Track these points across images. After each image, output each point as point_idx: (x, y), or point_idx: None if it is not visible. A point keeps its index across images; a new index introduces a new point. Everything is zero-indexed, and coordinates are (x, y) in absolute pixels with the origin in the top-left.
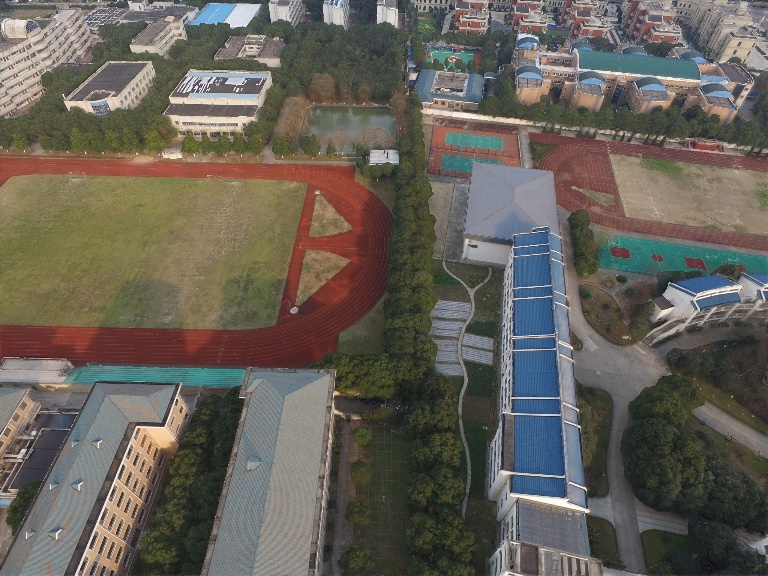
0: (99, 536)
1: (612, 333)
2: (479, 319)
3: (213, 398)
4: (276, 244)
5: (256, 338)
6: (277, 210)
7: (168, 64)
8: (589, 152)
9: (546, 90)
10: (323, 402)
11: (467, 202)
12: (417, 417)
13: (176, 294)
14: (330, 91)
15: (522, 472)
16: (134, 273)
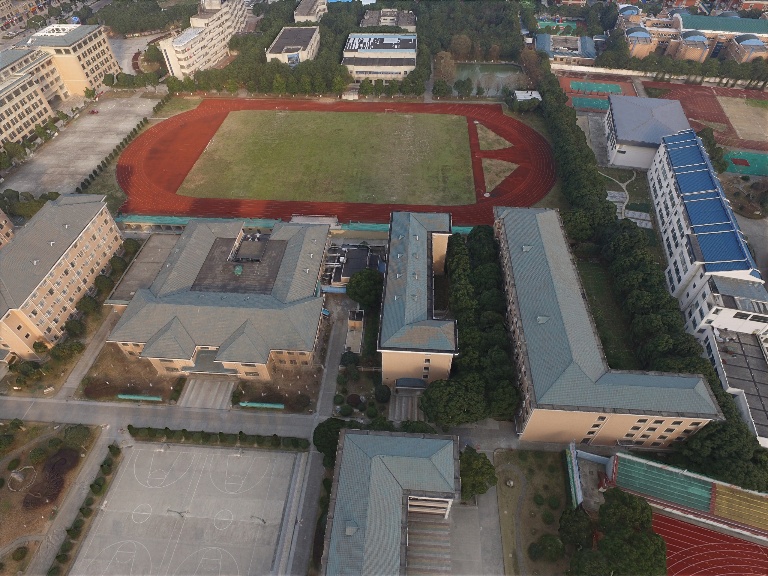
0: None
1: (745, 211)
2: (634, 202)
3: None
4: (457, 154)
5: (465, 210)
6: (448, 133)
7: None
8: (698, 95)
9: (653, 47)
10: (557, 223)
11: (614, 120)
12: (619, 241)
13: (393, 184)
14: (467, 49)
15: (712, 261)
16: (355, 171)
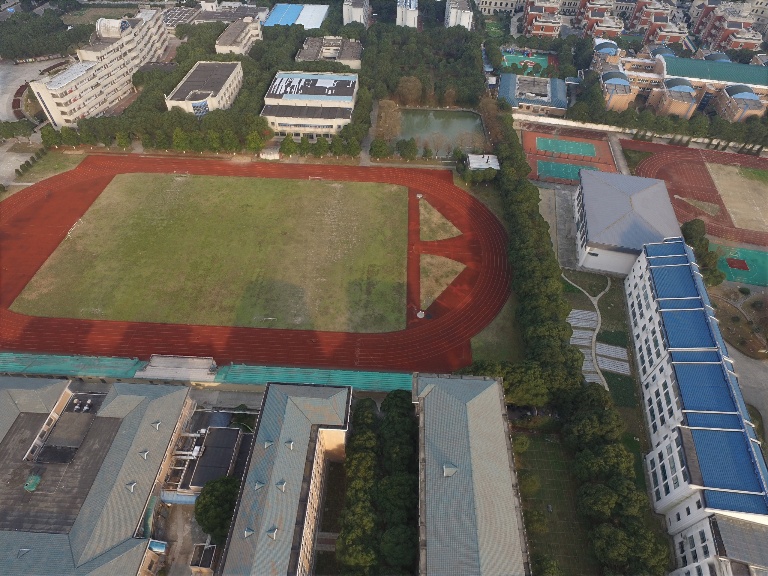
0: (305, 537)
1: (746, 346)
2: (608, 328)
3: (370, 401)
4: (389, 247)
5: (389, 342)
6: (383, 213)
7: (253, 65)
8: (684, 160)
9: (633, 96)
10: (498, 410)
11: (584, 210)
12: (585, 427)
13: (301, 295)
14: (417, 94)
15: (714, 487)
16: (256, 273)
